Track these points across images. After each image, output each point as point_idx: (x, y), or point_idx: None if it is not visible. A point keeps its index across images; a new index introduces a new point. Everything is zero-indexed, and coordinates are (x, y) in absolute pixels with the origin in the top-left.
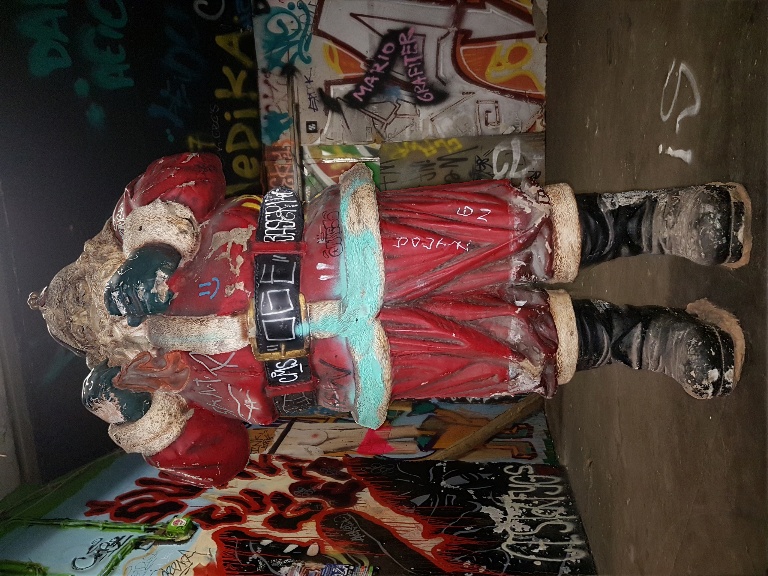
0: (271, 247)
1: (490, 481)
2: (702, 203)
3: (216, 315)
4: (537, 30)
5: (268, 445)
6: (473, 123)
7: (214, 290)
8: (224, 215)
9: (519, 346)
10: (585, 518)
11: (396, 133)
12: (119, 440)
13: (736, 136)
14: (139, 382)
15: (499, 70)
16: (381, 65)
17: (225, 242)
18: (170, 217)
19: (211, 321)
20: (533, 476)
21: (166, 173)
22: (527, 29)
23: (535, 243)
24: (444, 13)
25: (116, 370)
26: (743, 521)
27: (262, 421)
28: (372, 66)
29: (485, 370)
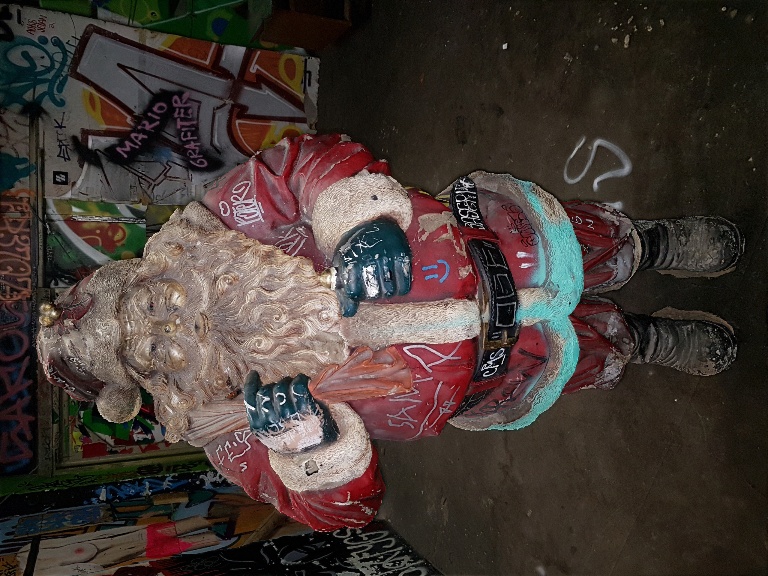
0: (479, 233)
1: (327, 549)
2: (718, 224)
3: (455, 298)
4: (308, 117)
5: (16, 575)
6: None
7: (444, 273)
8: (419, 198)
9: (612, 339)
10: (433, 559)
11: (165, 196)
12: (321, 467)
13: (692, 187)
14: (355, 385)
15: None
16: (150, 123)
17: (441, 224)
18: (399, 190)
19: (458, 303)
20: (363, 535)
21: (349, 147)
22: (299, 115)
23: (620, 251)
24: (220, 85)
25: (306, 377)
26: (741, 466)
27: (439, 429)
28: (140, 122)
29: (593, 362)
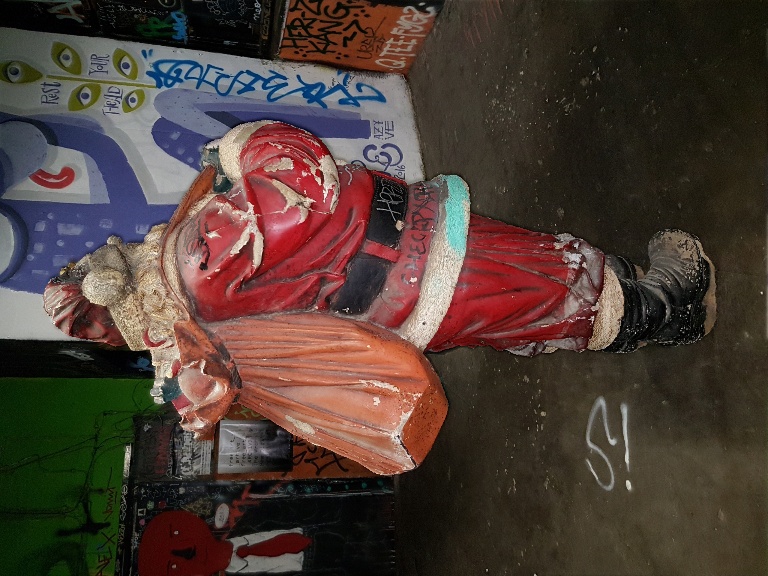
0: None
1: None
2: None
3: None
4: None
5: None
6: None
7: None
8: None
9: None
10: None
11: None
12: None
13: None
14: None
15: None
16: None
17: None
18: None
19: None
20: None
21: None
22: None
23: None
24: None
25: None
26: None
27: None
28: None
29: None
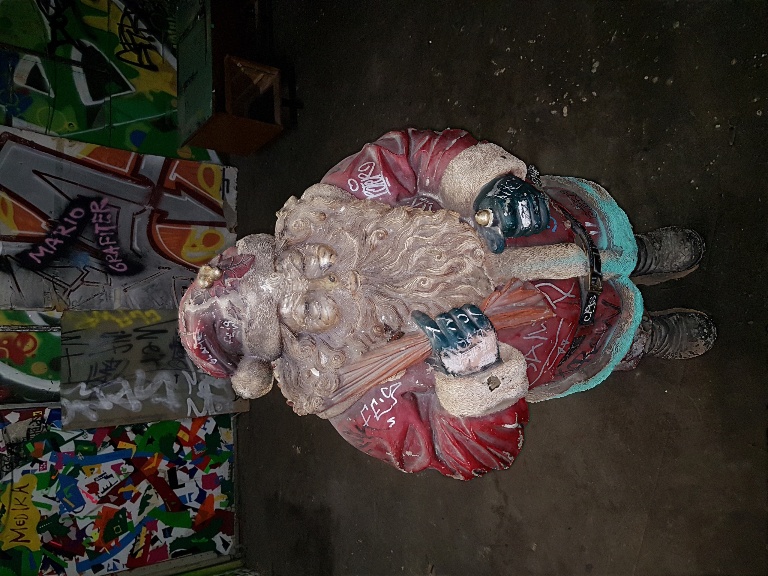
0: None
1: None
2: (684, 229)
3: None
4: (227, 222)
5: None
6: (170, 297)
7: (554, 224)
8: None
9: None
10: None
11: (81, 301)
12: (503, 380)
13: (645, 212)
14: (515, 309)
15: (194, 251)
16: (67, 228)
17: None
18: None
19: None
20: None
21: (456, 132)
22: (219, 220)
23: None
24: (140, 192)
25: None
26: (739, 431)
27: None
28: (56, 228)
29: None
